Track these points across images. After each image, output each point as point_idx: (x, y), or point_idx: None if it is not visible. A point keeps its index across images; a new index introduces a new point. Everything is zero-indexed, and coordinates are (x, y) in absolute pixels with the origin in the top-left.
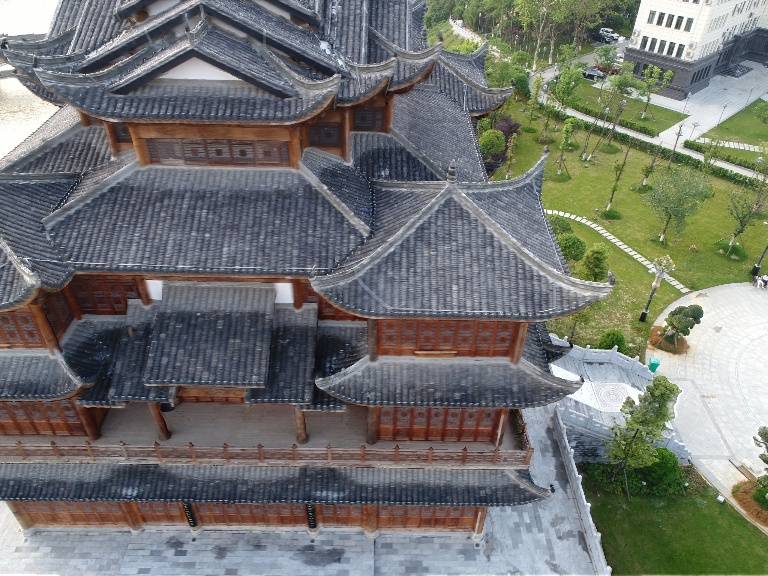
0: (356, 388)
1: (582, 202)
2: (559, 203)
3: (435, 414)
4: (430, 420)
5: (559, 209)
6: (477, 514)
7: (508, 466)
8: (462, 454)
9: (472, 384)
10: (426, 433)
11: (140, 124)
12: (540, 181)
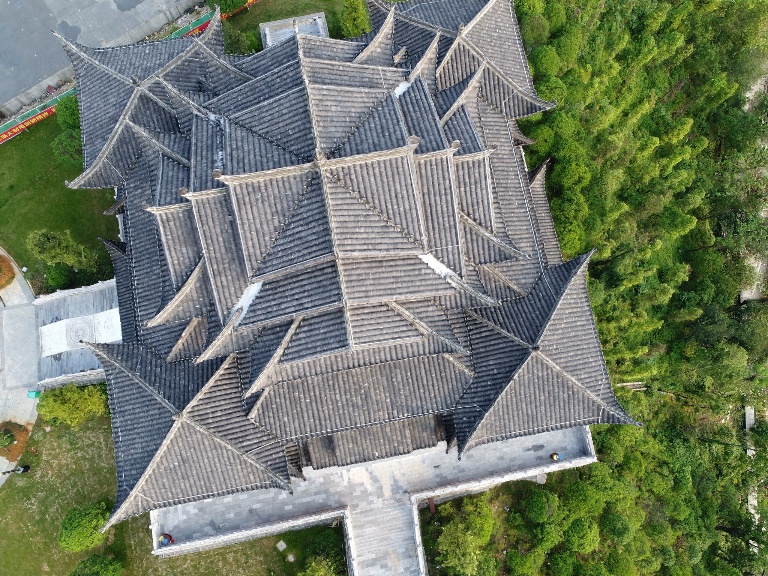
0: None
1: None
2: None
3: None
4: None
5: None
6: None
7: None
8: None
9: None
10: None
11: None
12: None
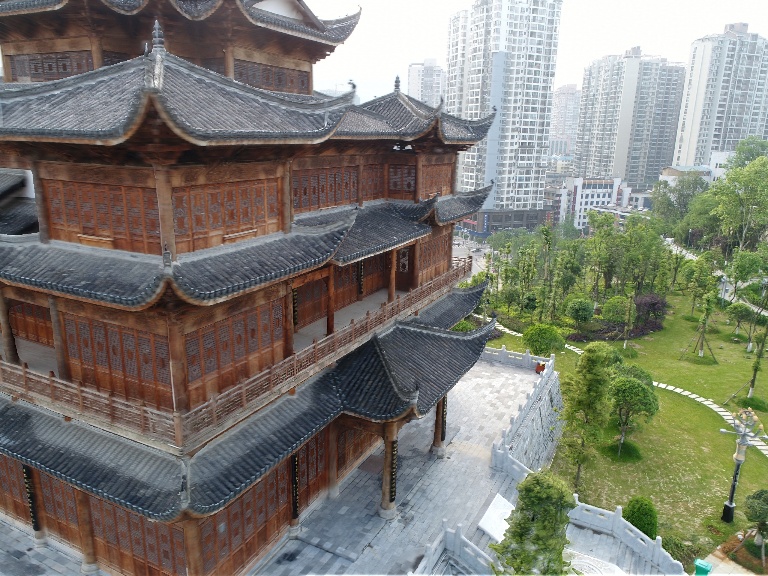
0: (4, 260)
1: (717, 385)
2: (683, 381)
3: (113, 349)
4: (110, 359)
5: (678, 386)
6: (186, 573)
7: (159, 442)
8: (109, 403)
9: (106, 276)
10: (111, 384)
11: (5, 42)
12: (337, 116)
